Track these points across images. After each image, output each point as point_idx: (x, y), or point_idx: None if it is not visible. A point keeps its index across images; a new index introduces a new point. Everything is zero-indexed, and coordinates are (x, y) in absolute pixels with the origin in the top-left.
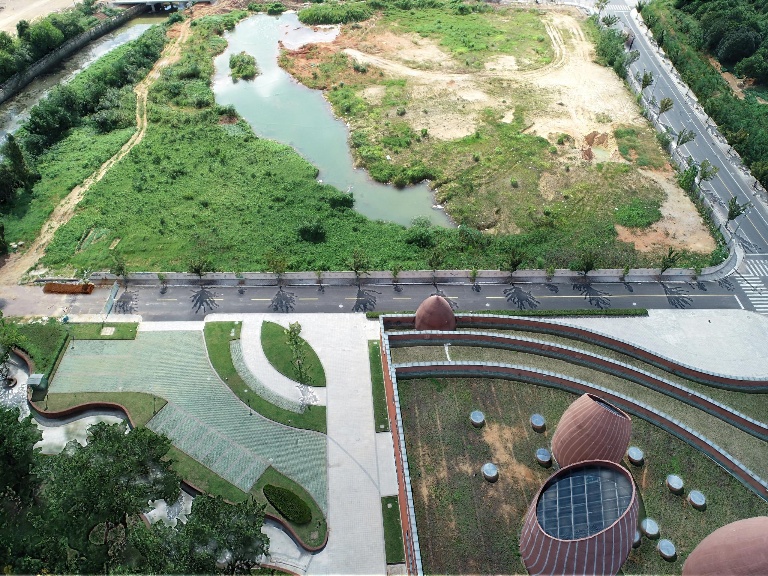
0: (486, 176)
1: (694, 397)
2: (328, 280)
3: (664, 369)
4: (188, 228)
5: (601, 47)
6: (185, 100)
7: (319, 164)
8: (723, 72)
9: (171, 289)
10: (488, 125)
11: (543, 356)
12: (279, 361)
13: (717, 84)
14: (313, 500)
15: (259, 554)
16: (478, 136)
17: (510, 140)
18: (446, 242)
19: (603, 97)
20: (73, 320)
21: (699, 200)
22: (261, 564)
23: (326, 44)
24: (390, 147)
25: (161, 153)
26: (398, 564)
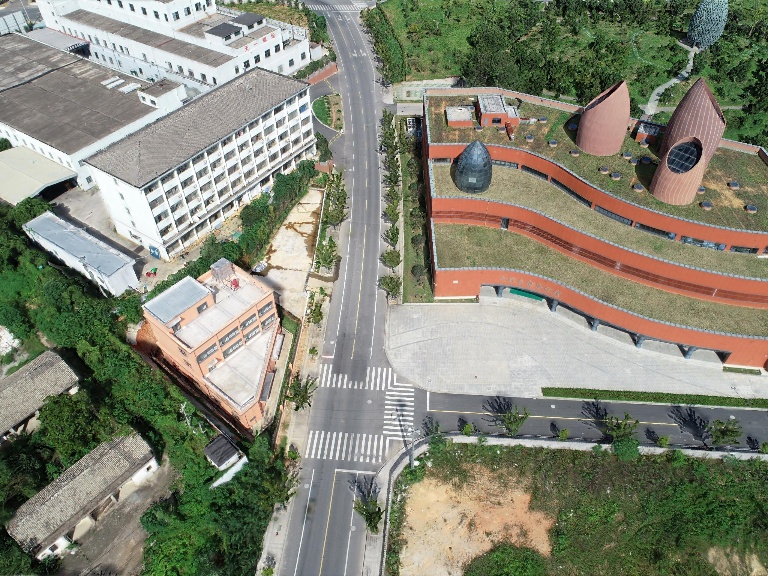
0: None
1: None
2: None
3: None
4: None
5: None
6: None
7: None
8: None
9: None
10: None
11: None
12: None
13: None
14: None
15: None
16: None
17: None
18: None
19: None
20: None
21: None
22: None
23: None
24: None
25: None
26: None
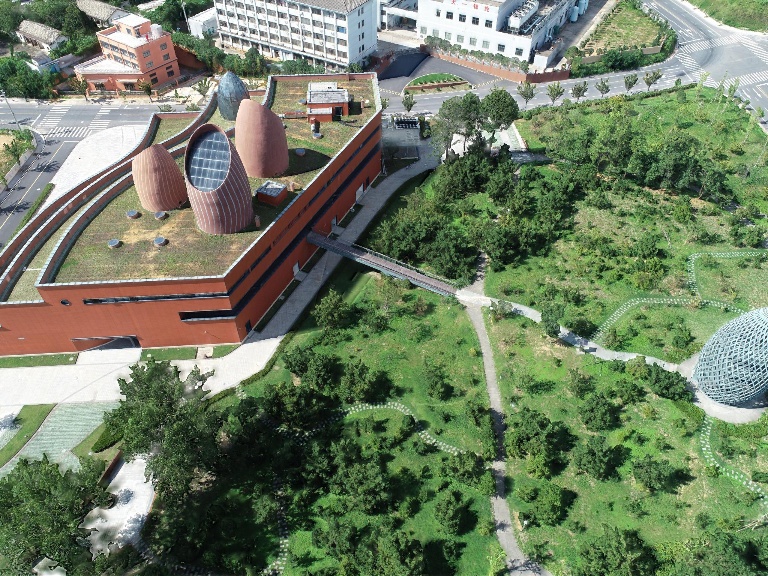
0: None
1: None
2: None
3: None
4: None
5: None
6: None
7: None
8: None
9: None
10: None
11: (72, 216)
12: None
13: None
14: None
15: None
16: None
17: None
18: None
19: None
20: None
21: None
22: None
23: None
24: None
25: None
26: (197, 352)
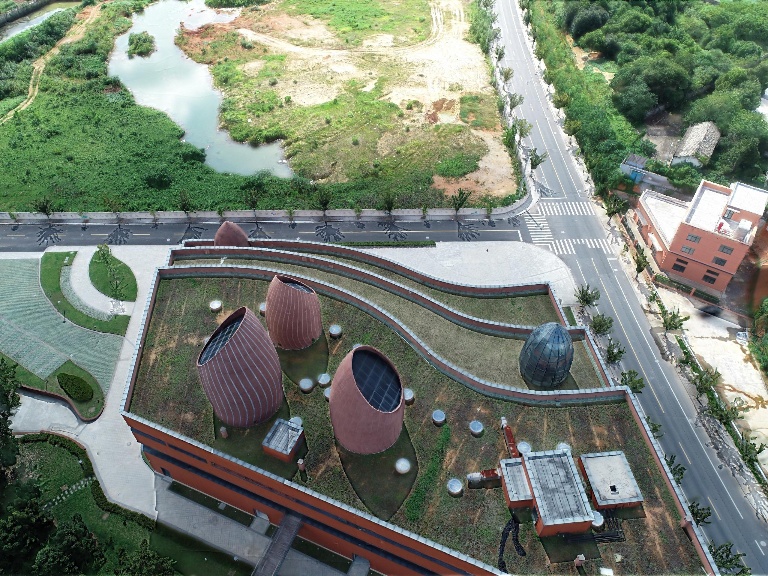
0: (332, 136)
1: (413, 294)
2: (163, 219)
3: (416, 281)
4: (50, 178)
5: (473, 26)
6: (77, 72)
7: (187, 127)
8: (573, 47)
9: (22, 227)
10: (349, 93)
11: (302, 266)
12: (100, 282)
13: (565, 57)
14: (98, 385)
15: (10, 404)
16: (336, 102)
17: (364, 106)
18: (277, 189)
19: (462, 69)
20: None
21: (515, 154)
22: (41, 431)
23: (223, 24)
24: (253, 112)
25: (43, 117)
26: None
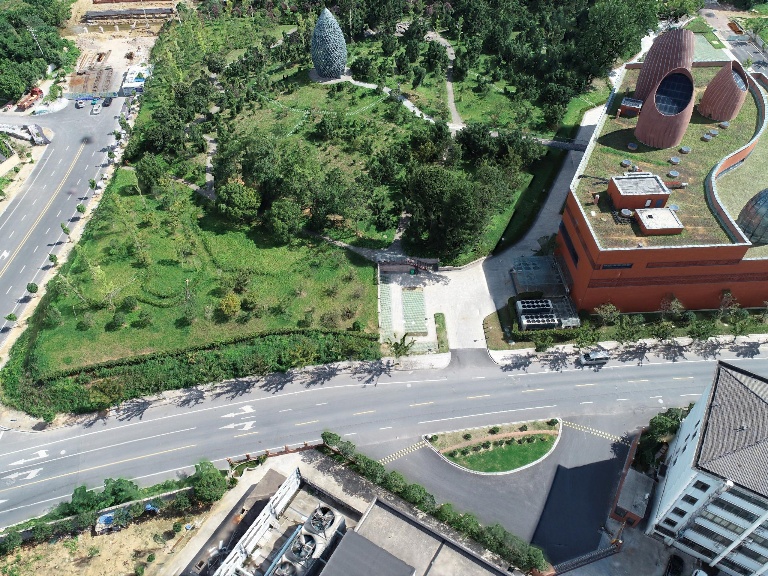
0: None
1: None
2: None
3: None
4: None
5: None
6: None
7: None
8: None
9: (759, 54)
10: None
11: None
12: None
13: None
14: None
15: (619, 49)
16: None
17: None
18: None
19: None
20: (715, 33)
21: None
22: None
23: None
24: None
25: None
26: None
